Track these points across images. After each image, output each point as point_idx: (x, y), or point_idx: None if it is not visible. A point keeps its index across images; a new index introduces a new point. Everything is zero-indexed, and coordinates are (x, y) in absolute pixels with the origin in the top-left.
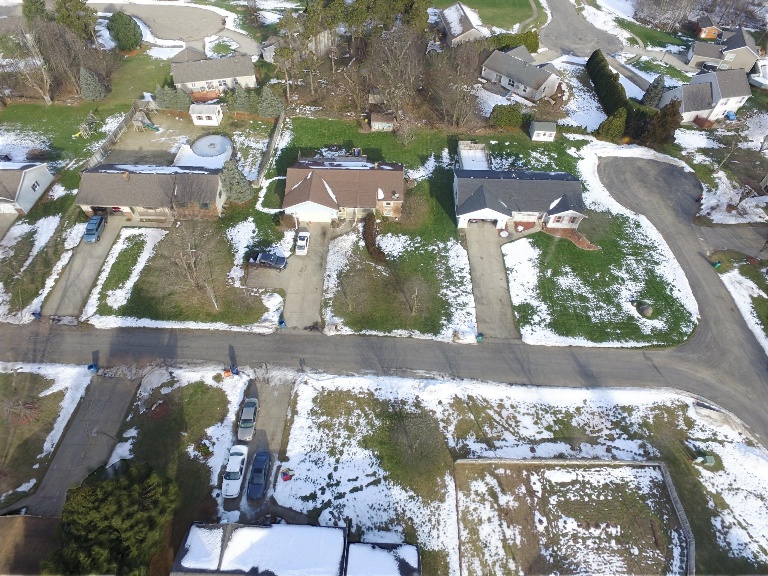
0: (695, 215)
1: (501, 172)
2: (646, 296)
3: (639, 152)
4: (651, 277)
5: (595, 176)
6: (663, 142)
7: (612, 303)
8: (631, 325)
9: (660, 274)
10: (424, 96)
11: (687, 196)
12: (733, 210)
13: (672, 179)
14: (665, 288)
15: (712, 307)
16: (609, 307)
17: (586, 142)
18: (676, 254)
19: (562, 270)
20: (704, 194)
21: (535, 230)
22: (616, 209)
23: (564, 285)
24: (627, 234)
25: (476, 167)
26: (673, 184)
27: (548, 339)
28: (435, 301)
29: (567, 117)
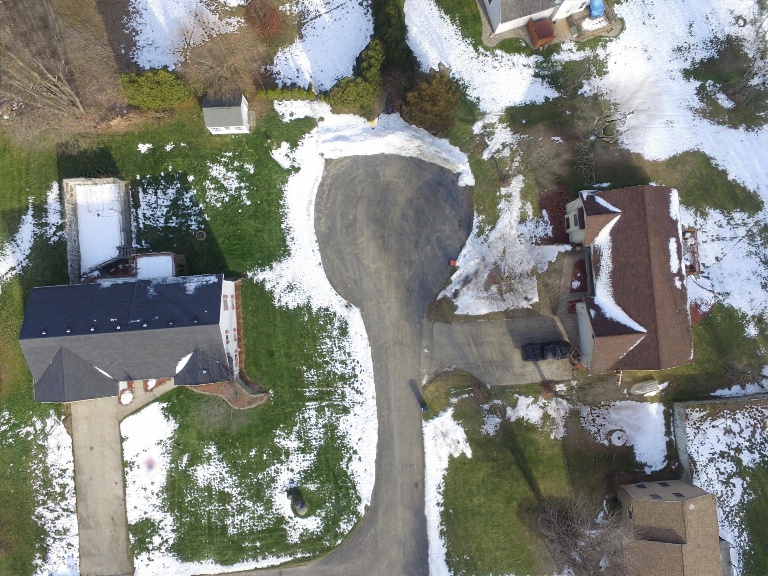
0: (435, 297)
1: (106, 294)
2: (311, 478)
3: (395, 143)
4: (329, 440)
5: (308, 215)
6: (431, 129)
7: (261, 499)
8: (276, 532)
9: (343, 432)
10: (20, 6)
11: (439, 252)
12: (493, 284)
13: (430, 210)
14: (341, 458)
15: (391, 484)
16: (255, 507)
17: (310, 124)
18: (379, 388)
19: (203, 453)
20: (467, 244)
21: (173, 384)
22: (320, 297)
23: (202, 480)
24: (321, 354)
25: (102, 233)
26: (427, 224)
27: (166, 570)
28: (27, 530)
29: (296, 39)
